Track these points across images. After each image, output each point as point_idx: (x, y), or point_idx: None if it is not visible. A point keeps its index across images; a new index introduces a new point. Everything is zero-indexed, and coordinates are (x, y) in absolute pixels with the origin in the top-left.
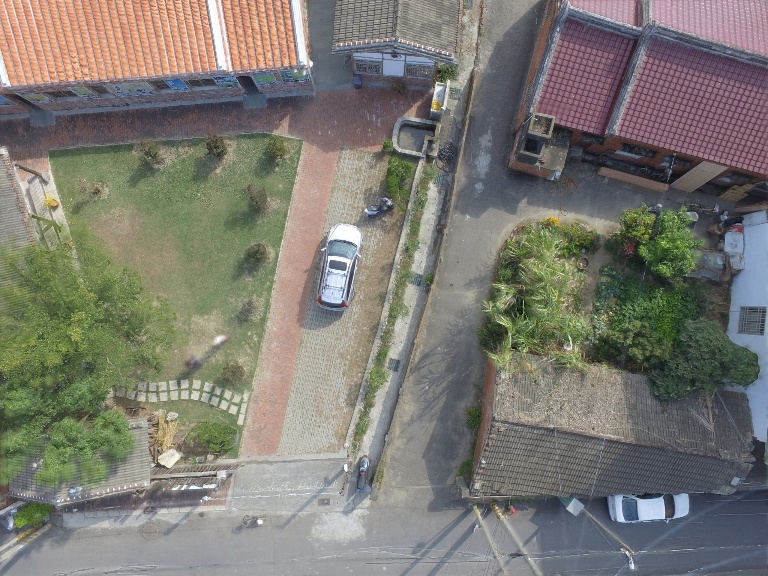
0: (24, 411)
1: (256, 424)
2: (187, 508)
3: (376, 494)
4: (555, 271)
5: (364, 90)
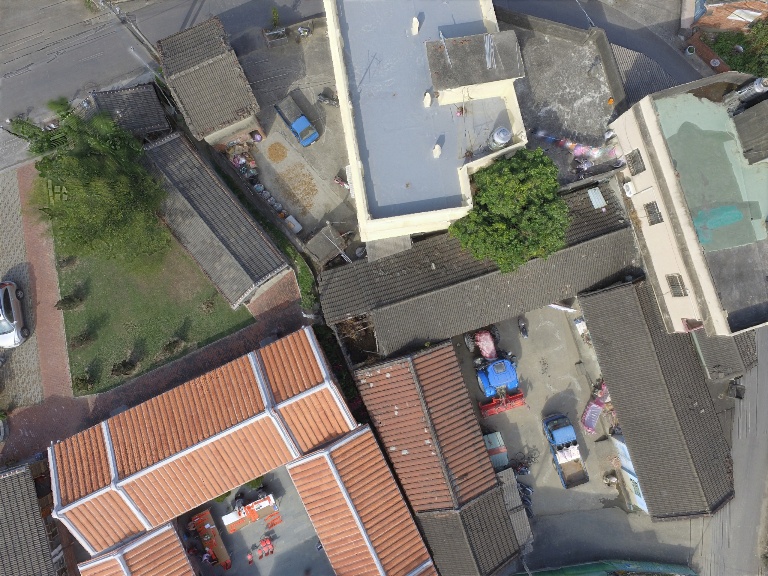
0: None
1: (39, 185)
2: None
3: None
4: None
5: None
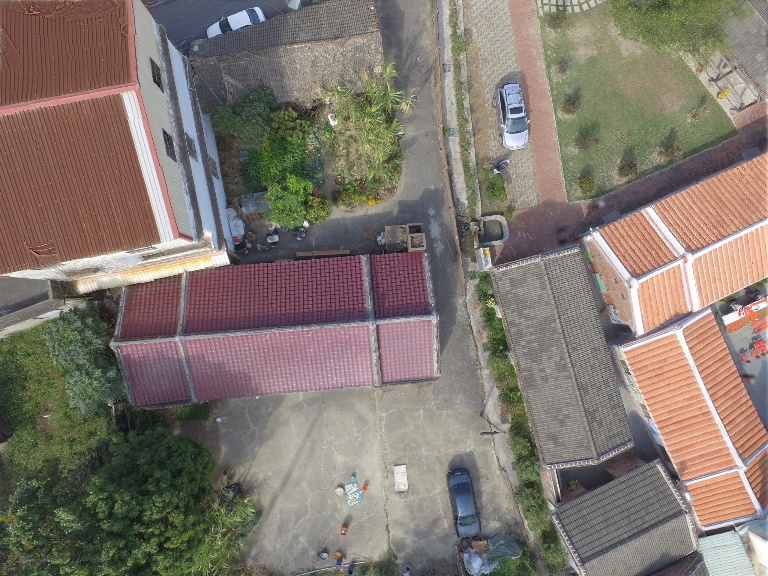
0: None
1: None
2: None
3: None
4: None
5: None
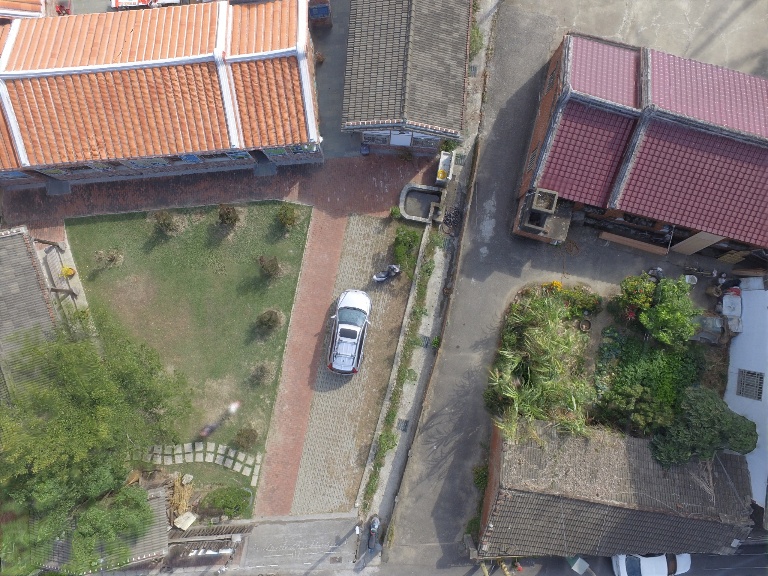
0: (50, 498)
1: (269, 485)
2: (202, 567)
3: (387, 556)
4: (559, 345)
5: (371, 157)
